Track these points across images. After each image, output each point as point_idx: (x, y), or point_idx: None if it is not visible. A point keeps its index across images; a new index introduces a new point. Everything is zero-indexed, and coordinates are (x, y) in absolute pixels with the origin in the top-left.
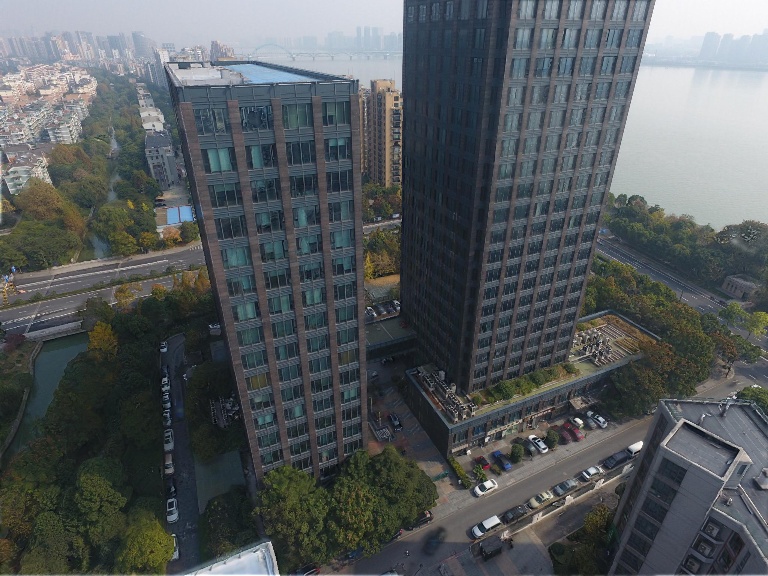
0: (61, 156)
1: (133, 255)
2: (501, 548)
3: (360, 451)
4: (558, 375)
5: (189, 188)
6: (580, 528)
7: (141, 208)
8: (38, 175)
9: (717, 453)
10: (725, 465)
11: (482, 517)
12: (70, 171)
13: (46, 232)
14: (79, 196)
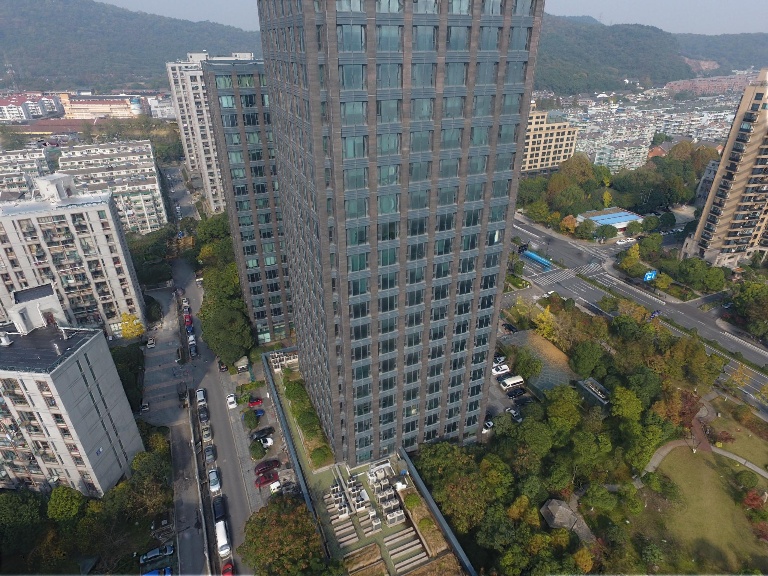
0: (676, 151)
1: (540, 224)
2: (183, 401)
3: (242, 303)
4: (307, 439)
5: (696, 210)
6: (170, 450)
7: (603, 200)
8: (619, 156)
9: (27, 300)
10: (18, 299)
11: (211, 398)
12: (664, 165)
13: (526, 185)
14: (618, 181)
